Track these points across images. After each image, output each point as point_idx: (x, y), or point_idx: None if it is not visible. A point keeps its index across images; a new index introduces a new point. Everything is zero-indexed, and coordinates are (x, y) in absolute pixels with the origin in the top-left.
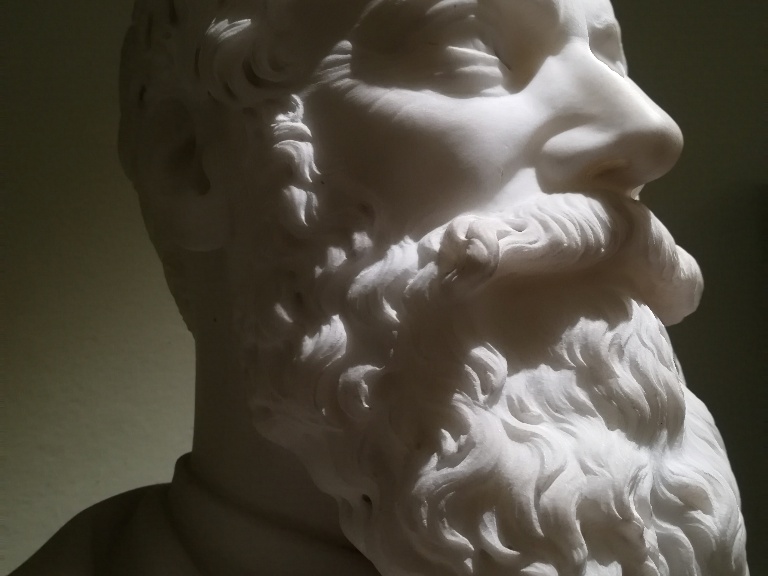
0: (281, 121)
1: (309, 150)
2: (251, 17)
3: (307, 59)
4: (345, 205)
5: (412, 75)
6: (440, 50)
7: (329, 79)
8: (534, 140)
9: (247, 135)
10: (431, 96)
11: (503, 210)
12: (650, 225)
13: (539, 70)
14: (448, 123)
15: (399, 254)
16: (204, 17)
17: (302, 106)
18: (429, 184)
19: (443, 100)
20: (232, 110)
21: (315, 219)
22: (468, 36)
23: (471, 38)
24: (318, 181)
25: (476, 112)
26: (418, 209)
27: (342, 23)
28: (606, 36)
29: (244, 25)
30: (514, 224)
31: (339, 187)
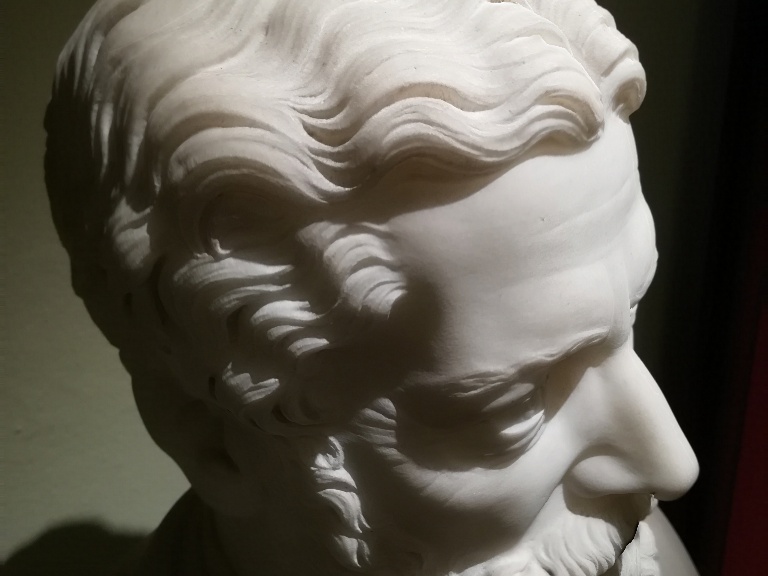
0: (322, 468)
1: (356, 505)
2: (278, 377)
3: (343, 405)
4: (395, 553)
5: (462, 452)
6: (492, 434)
7: (372, 440)
8: None
9: (283, 464)
10: (480, 475)
11: (534, 539)
12: (650, 506)
13: (578, 385)
14: (495, 499)
15: None
16: (216, 358)
17: (342, 452)
18: (473, 537)
19: (491, 476)
20: (260, 431)
21: (368, 564)
22: (520, 413)
23: (523, 414)
24: (368, 531)
25: (521, 478)
26: (461, 549)
27: (382, 380)
28: None
29: (272, 387)
30: (545, 566)
31: (388, 537)
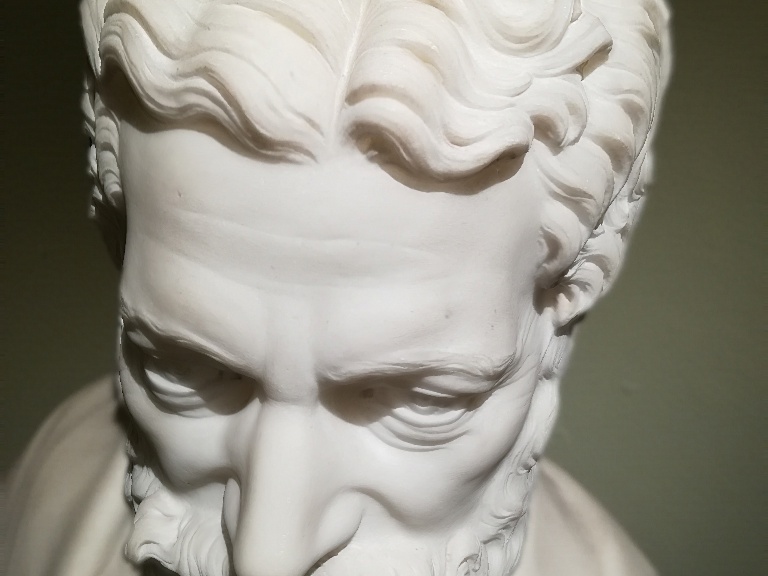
0: None
1: None
2: (95, 208)
3: None
4: None
5: (139, 365)
6: None
7: None
8: (218, 473)
9: None
10: (143, 397)
11: (191, 506)
12: None
13: (247, 406)
14: (149, 428)
15: (142, 479)
16: None
17: None
18: None
19: (149, 406)
20: None
21: None
22: (160, 367)
23: (162, 370)
24: None
25: (168, 431)
26: None
27: None
28: (359, 381)
29: (92, 213)
30: None
31: None
